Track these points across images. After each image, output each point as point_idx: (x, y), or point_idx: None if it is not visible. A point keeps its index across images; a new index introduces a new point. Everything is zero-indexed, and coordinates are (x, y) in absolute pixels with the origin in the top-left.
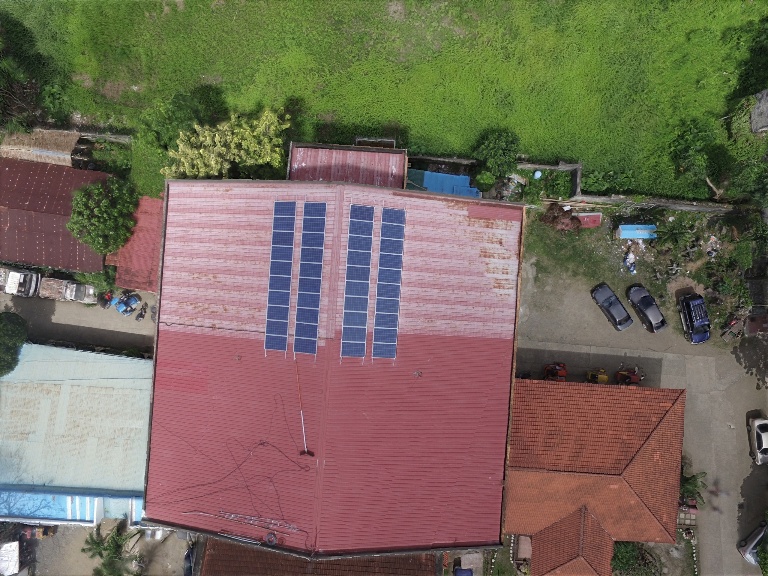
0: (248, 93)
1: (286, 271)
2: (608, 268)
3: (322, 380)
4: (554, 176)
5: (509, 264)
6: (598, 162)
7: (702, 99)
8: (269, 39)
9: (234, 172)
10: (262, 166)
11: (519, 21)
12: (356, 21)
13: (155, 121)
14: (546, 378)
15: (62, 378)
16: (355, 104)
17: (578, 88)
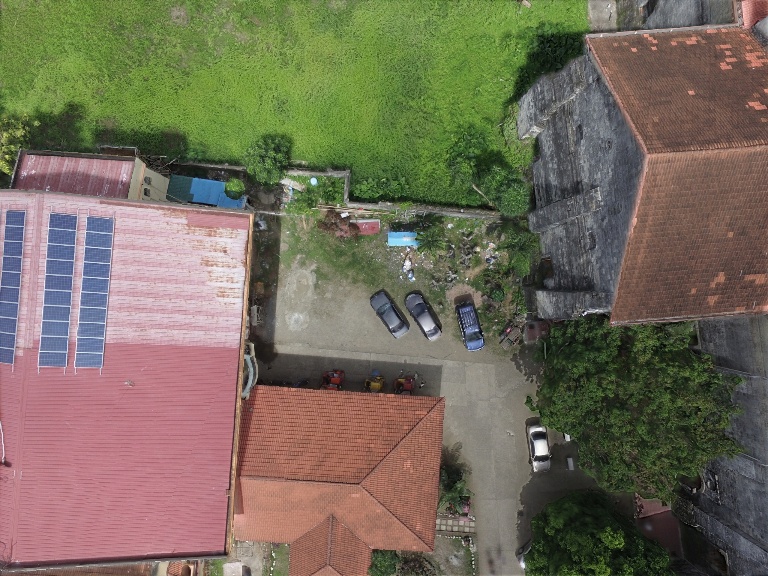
0: (27, 98)
1: None
2: (388, 275)
3: (19, 390)
4: (328, 183)
5: (234, 273)
6: (371, 169)
7: (481, 106)
8: (49, 44)
9: None
10: (4, 173)
11: (298, 27)
12: (138, 26)
13: None
14: (321, 385)
15: None
16: (133, 110)
17: (356, 94)
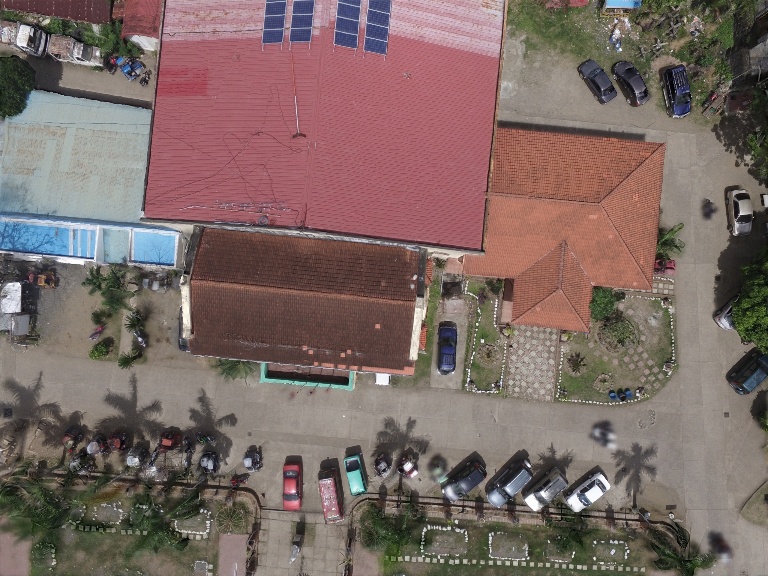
0: None
1: None
2: (595, 46)
3: (316, 66)
4: None
5: None
6: None
7: None
8: None
9: None
10: None
11: None
12: None
13: None
14: None
15: (68, 122)
16: None
17: None
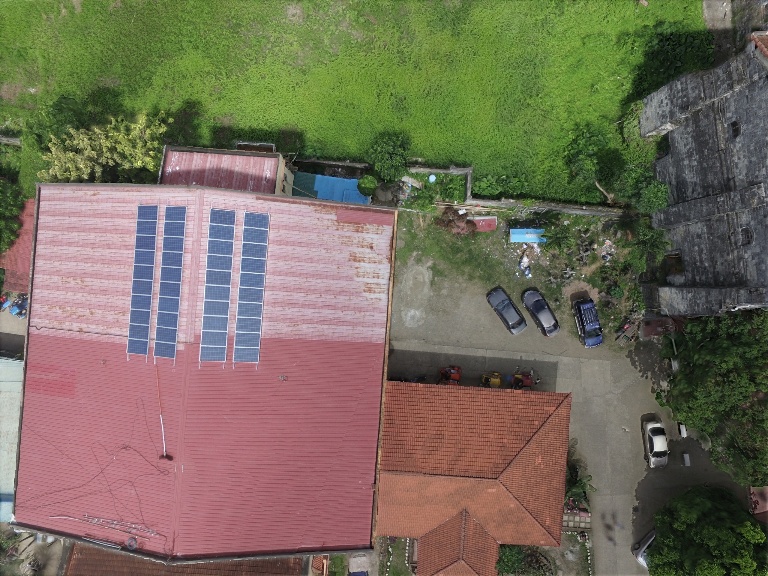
0: (145, 96)
1: (148, 275)
2: (504, 272)
3: (181, 384)
4: (447, 180)
5: (380, 268)
6: (491, 166)
7: (597, 104)
8: (167, 42)
9: (113, 175)
10: (142, 169)
11: (415, 25)
12: (254, 24)
13: (36, 124)
14: (440, 381)
15: None
16: (251, 107)
17: (473, 92)
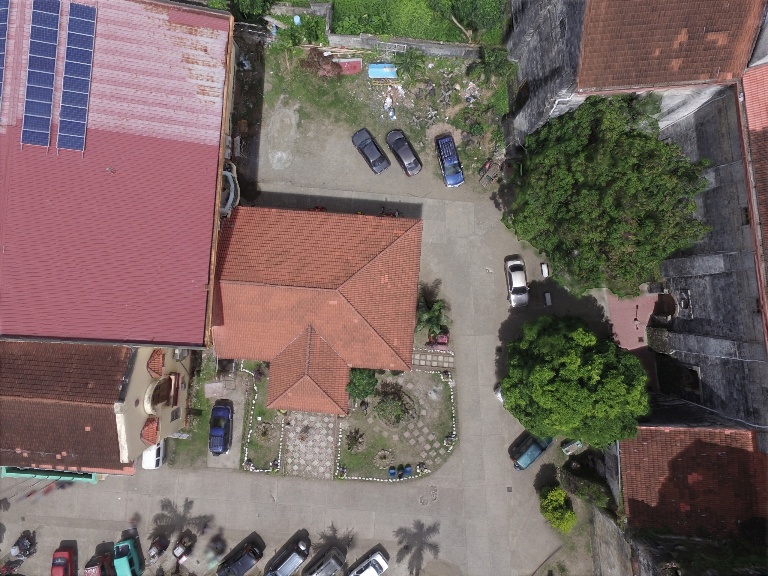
0: None
1: None
2: (369, 114)
3: (2, 166)
4: (310, 19)
5: (215, 72)
6: (353, 5)
7: None
8: None
9: None
10: None
11: None
12: None
13: None
14: None
15: None
16: None
17: None
